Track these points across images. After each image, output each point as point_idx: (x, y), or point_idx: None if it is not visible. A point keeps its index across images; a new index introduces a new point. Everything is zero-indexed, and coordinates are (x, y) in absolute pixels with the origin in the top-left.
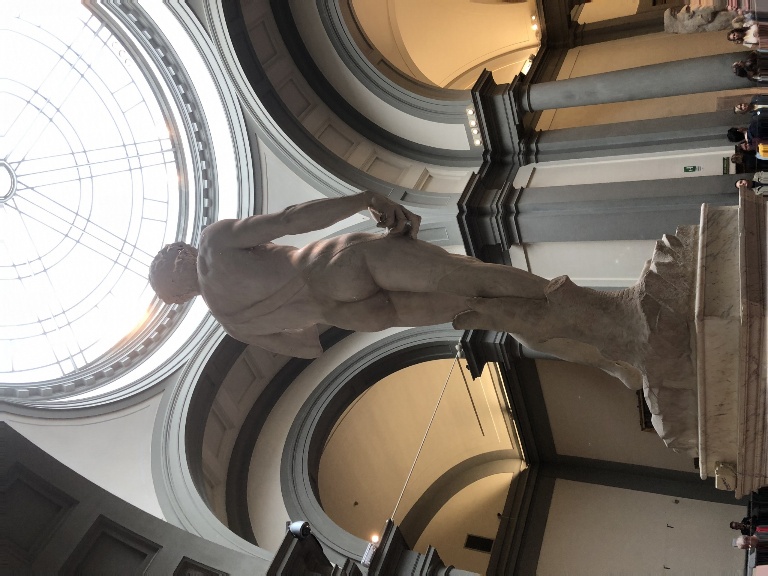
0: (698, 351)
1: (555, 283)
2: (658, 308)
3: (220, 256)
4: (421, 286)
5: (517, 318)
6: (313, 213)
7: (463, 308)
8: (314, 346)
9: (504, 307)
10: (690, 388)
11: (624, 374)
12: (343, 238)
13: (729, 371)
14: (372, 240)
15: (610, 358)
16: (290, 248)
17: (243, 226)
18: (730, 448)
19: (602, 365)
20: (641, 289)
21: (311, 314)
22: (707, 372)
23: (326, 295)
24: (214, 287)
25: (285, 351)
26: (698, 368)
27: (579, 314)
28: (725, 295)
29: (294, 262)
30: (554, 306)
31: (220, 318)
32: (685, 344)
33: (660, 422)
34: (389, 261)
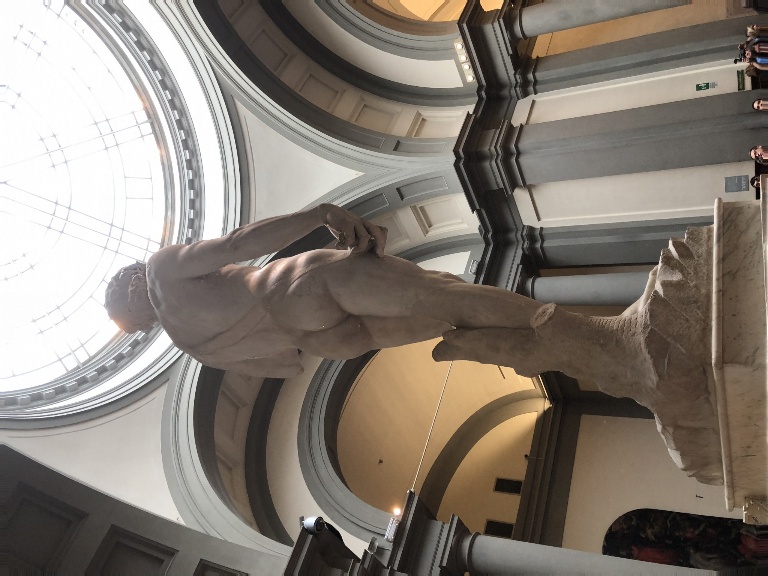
0: (718, 398)
1: (542, 314)
2: (666, 347)
3: (169, 289)
4: (393, 312)
5: (502, 353)
6: (262, 237)
7: (446, 324)
8: (293, 365)
9: (486, 341)
10: (711, 427)
11: None
12: (301, 260)
13: (757, 416)
14: (333, 262)
15: None
16: (248, 270)
17: (188, 256)
18: (761, 486)
19: None
20: (645, 321)
21: (279, 342)
22: (730, 416)
23: (290, 325)
24: (171, 319)
25: (262, 373)
26: (719, 414)
27: (573, 350)
28: (748, 332)
29: (252, 288)
30: (543, 340)
31: None
32: (702, 388)
33: (678, 455)
34: (354, 286)
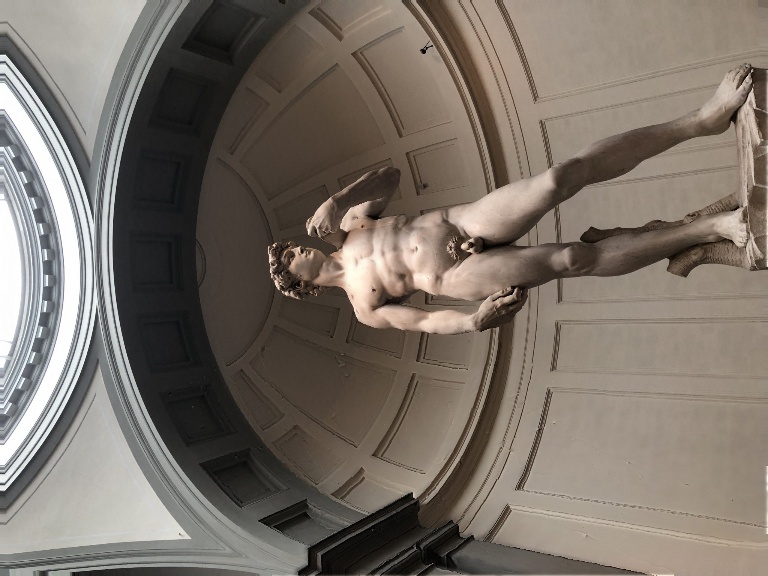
0: None
1: None
2: None
3: None
4: None
5: None
6: None
7: None
8: None
9: None
10: None
11: None
12: None
13: None
14: None
15: None
16: (409, 289)
17: None
18: None
19: None
20: None
21: None
22: None
23: None
24: None
25: None
26: None
27: None
28: None
29: None
30: None
31: None
32: None
33: None
34: None
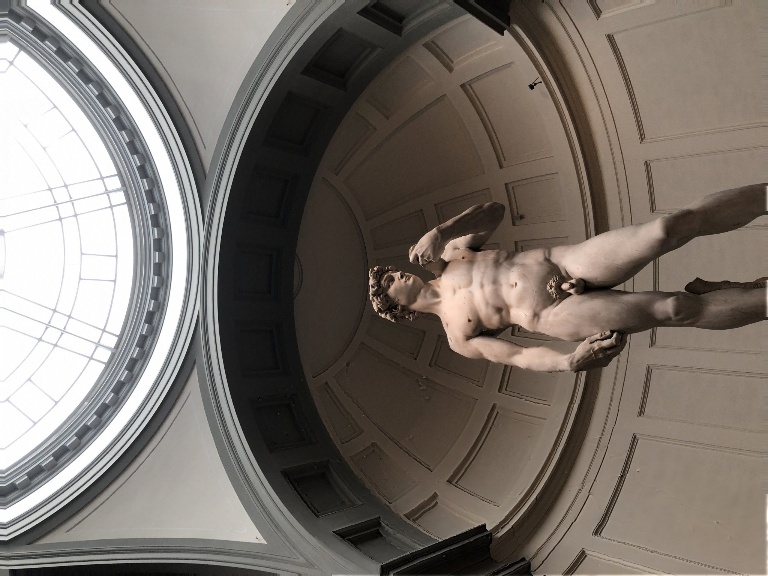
0: None
1: None
2: None
3: None
4: None
5: None
6: None
7: None
8: None
9: None
10: None
11: None
12: None
13: None
14: None
15: None
16: None
17: None
18: None
19: None
20: None
21: None
22: None
23: None
24: None
25: None
26: None
27: None
28: None
29: None
30: None
31: None
32: None
33: None
34: None
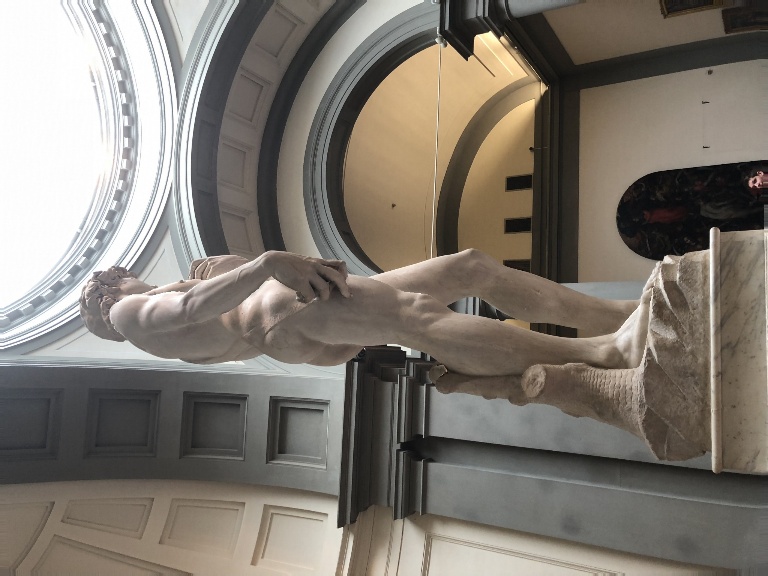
0: None
1: (533, 383)
2: (665, 431)
3: (146, 345)
4: None
5: None
6: (217, 307)
7: None
8: None
9: (480, 391)
10: None
11: None
12: (265, 305)
13: None
14: (299, 310)
15: None
16: None
17: (149, 325)
18: None
19: None
20: (640, 398)
21: None
22: None
23: None
24: None
25: None
26: None
27: (570, 409)
28: (749, 431)
29: (226, 325)
30: None
31: None
32: None
33: None
34: (330, 333)
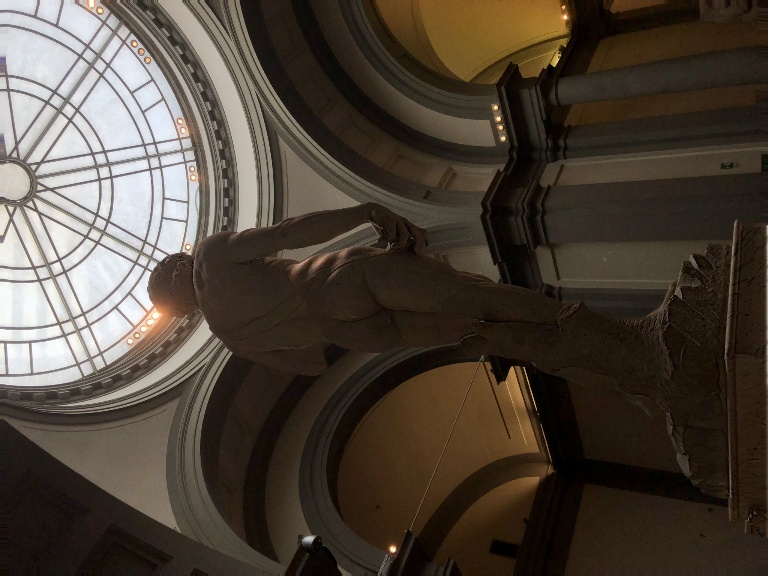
0: (728, 391)
1: (568, 308)
2: (683, 341)
3: (215, 271)
4: (424, 306)
5: (526, 345)
6: (310, 227)
7: None
8: (318, 363)
9: (512, 333)
10: (719, 428)
11: (647, 404)
12: (343, 253)
13: (764, 414)
14: (373, 256)
15: (629, 392)
16: (289, 262)
17: (238, 240)
18: (765, 495)
19: (623, 393)
20: (664, 318)
21: (311, 332)
22: (739, 413)
23: (325, 313)
24: (211, 302)
25: (287, 368)
26: (728, 409)
27: (594, 344)
28: (760, 329)
29: (292, 277)
30: (566, 334)
31: (218, 334)
32: (713, 382)
33: (686, 462)
34: (390, 279)
